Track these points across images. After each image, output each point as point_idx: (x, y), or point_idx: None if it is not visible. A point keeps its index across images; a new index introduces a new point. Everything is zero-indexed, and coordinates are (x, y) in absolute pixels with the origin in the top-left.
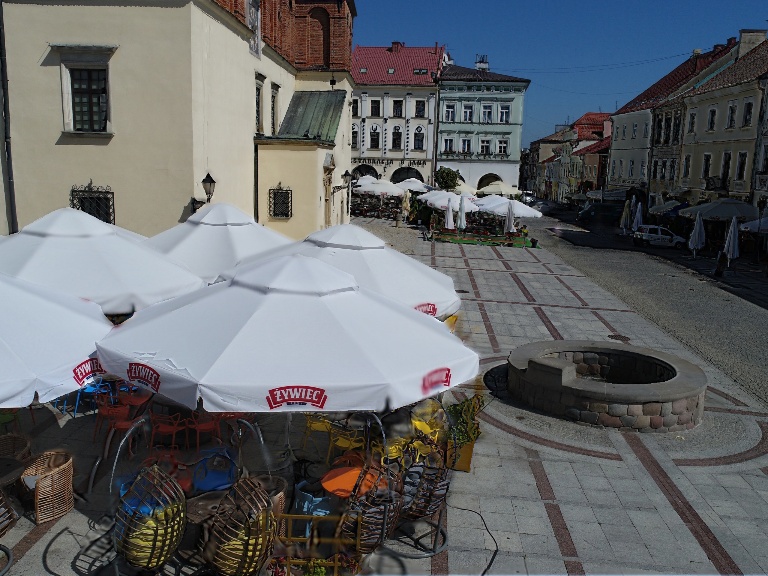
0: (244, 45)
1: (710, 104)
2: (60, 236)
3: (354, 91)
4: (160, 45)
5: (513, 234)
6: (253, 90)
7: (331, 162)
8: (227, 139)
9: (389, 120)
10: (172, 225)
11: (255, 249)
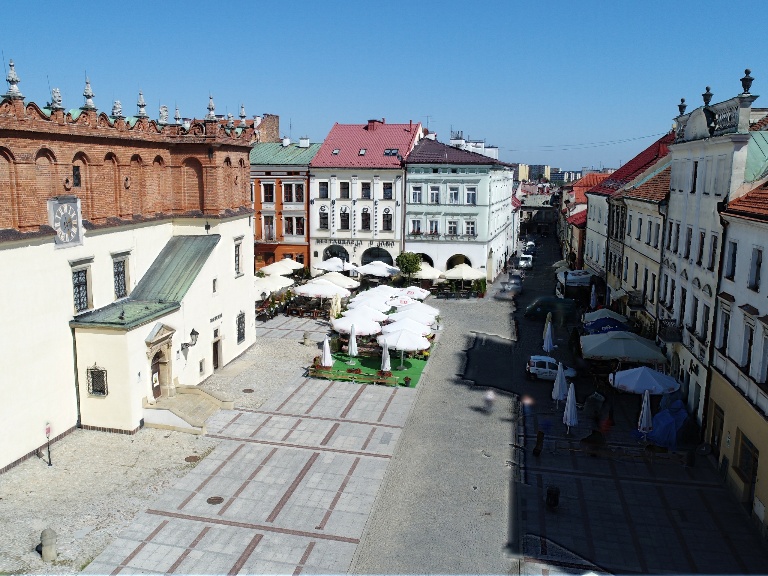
0: (41, 249)
1: (638, 212)
2: None
3: (323, 174)
4: None
5: (384, 374)
6: (66, 279)
7: (162, 331)
8: (5, 350)
9: (358, 202)
10: None
11: None
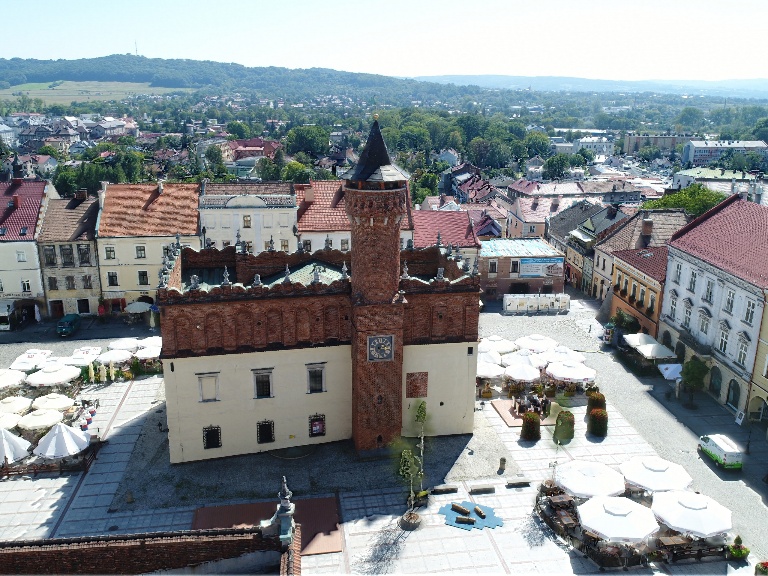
0: None
1: (136, 243)
2: None
3: None
4: None
5: None
6: None
7: None
8: None
9: None
10: None
11: None
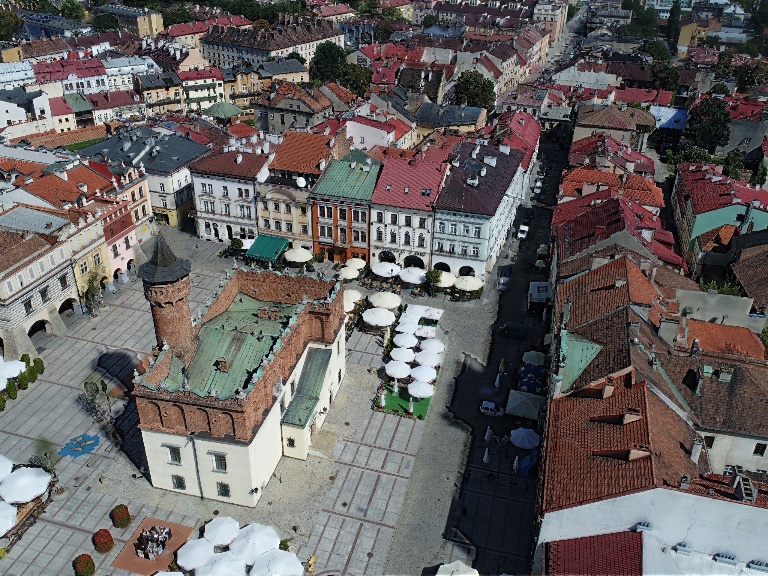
0: None
1: None
2: (218, 574)
3: (380, 208)
4: (240, 454)
5: None
6: None
7: None
8: None
9: (402, 227)
10: (247, 494)
11: (261, 550)
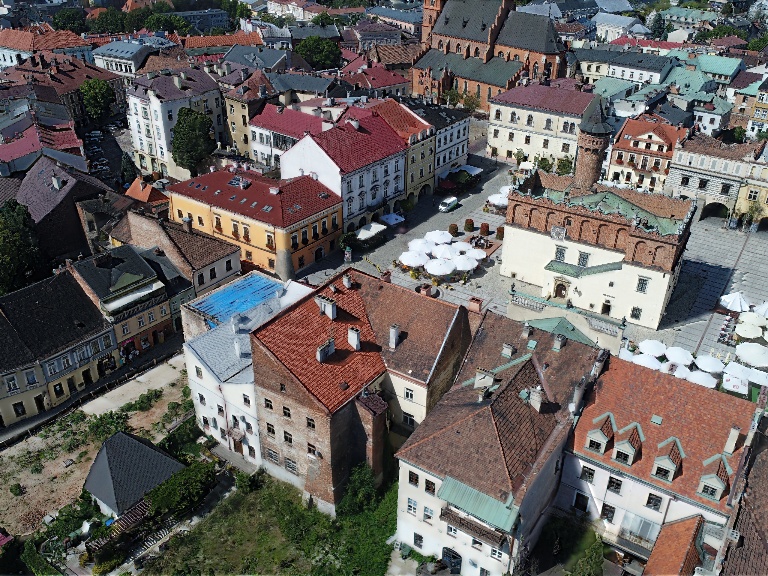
0: None
1: None
2: None
3: None
4: None
5: None
6: None
7: (562, 278)
8: None
9: None
10: None
11: None
